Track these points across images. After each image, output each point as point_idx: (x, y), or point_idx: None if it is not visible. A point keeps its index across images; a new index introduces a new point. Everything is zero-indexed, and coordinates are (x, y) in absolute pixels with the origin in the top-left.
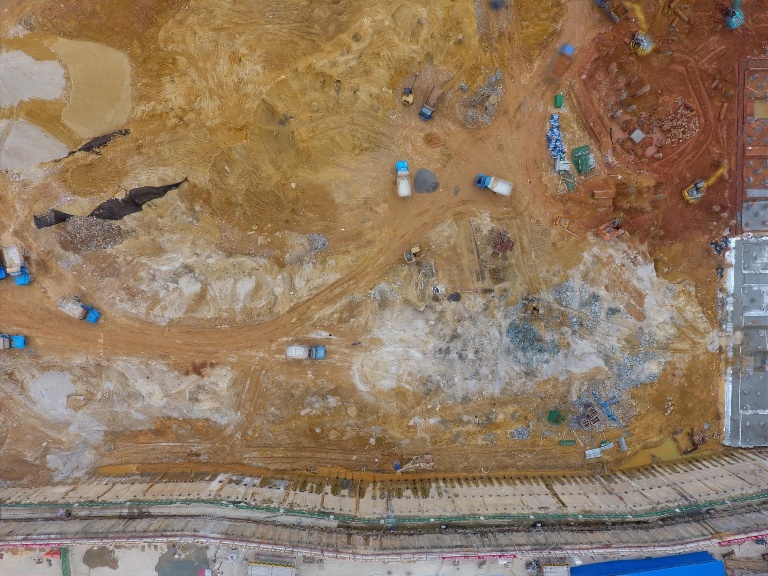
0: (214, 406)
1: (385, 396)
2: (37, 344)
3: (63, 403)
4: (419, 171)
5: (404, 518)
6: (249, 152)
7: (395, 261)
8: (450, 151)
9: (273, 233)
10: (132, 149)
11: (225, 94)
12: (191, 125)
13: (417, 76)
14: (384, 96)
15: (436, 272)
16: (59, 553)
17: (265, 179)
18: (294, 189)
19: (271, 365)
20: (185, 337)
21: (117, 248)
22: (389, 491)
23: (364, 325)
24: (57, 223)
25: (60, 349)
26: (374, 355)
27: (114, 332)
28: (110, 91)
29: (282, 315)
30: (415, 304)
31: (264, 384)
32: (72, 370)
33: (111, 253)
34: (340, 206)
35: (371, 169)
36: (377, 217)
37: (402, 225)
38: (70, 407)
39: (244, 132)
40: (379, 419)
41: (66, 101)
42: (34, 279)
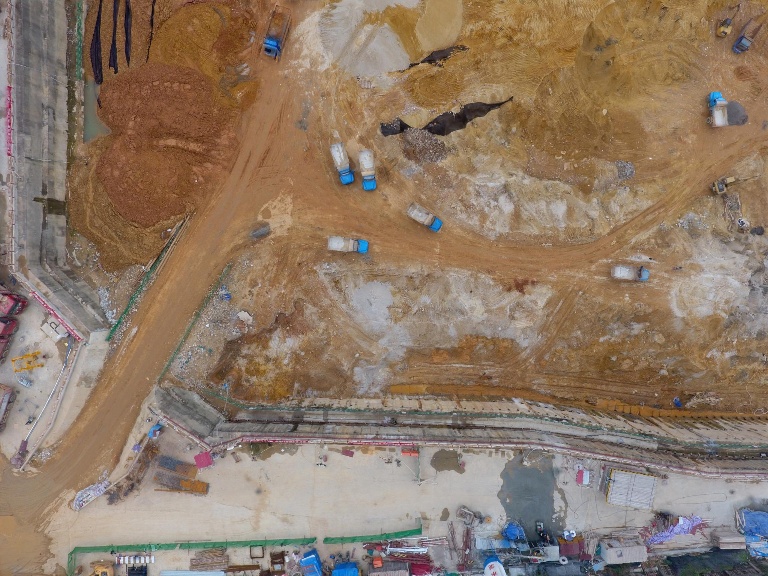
0: (528, 325)
1: (698, 323)
2: (374, 251)
3: (385, 313)
4: (729, 103)
5: (725, 444)
6: (573, 75)
7: (700, 192)
8: (761, 85)
9: (580, 159)
10: (470, 64)
11: (555, 16)
12: (522, 45)
13: (732, 9)
14: (700, 27)
15: (741, 205)
16: (416, 452)
17: (581, 104)
18: (604, 116)
19: (590, 286)
20: (510, 253)
21: (445, 163)
22: (679, 424)
23: (684, 250)
24: (400, 132)
25: (396, 257)
26: (693, 281)
27: (449, 243)
28: (451, 7)
29: (603, 236)
30: (726, 234)
31: (578, 306)
32: (396, 281)
33: (442, 166)
34: (649, 135)
35: (681, 100)
36: (685, 147)
37: (709, 157)
38: (391, 318)
39: (574, 54)
40: (681, 348)
41: (421, 11)
42: (376, 186)
